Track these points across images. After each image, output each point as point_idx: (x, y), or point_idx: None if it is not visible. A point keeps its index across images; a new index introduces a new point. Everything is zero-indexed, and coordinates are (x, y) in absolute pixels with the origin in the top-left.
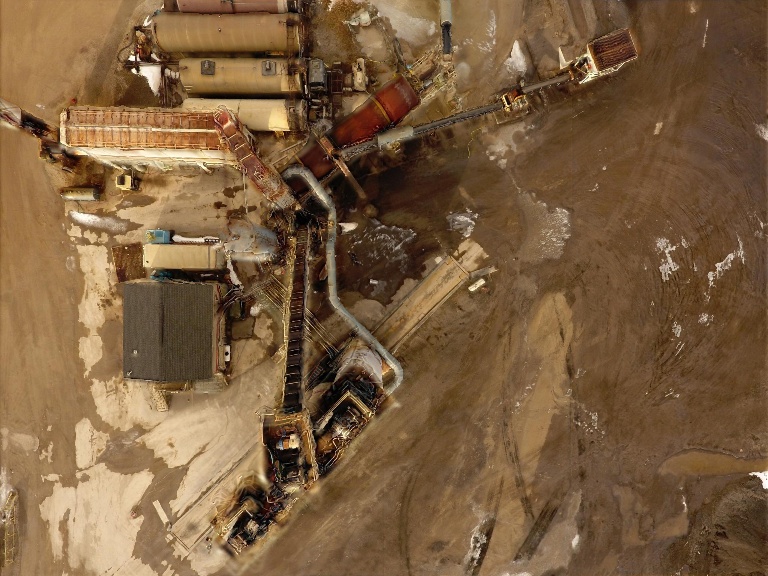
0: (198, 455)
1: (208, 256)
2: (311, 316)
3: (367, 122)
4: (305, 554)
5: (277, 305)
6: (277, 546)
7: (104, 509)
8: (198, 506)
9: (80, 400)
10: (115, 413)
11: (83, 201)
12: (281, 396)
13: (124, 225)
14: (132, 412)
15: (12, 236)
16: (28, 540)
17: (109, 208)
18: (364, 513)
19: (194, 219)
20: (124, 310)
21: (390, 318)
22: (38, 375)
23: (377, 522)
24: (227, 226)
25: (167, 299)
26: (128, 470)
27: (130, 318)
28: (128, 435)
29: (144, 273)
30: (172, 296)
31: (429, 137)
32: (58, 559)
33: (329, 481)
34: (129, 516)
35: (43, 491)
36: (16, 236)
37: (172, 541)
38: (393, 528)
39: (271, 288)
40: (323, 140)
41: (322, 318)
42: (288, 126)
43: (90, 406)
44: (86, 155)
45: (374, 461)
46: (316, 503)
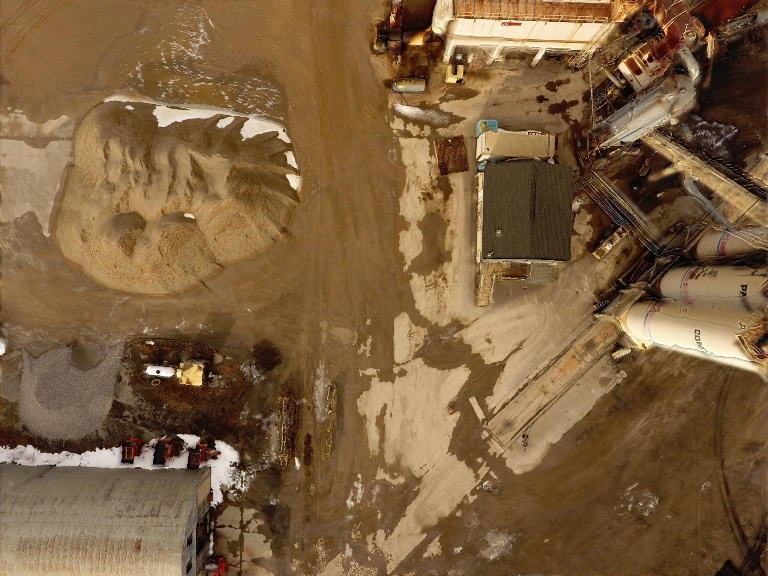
0: (515, 351)
1: (548, 144)
2: (631, 212)
3: (737, 1)
4: (620, 453)
5: (597, 201)
6: (592, 445)
7: (421, 404)
8: (514, 403)
9: (399, 294)
10: (433, 308)
11: (406, 93)
12: (600, 292)
13: (447, 118)
14: (451, 307)
15: (336, 128)
16: (345, 435)
17: (432, 101)
18: (679, 413)
19: (516, 113)
20: (485, 190)
21: (710, 215)
22: (358, 268)
23: (692, 422)
24: (672, 79)
25: (538, 176)
26: (445, 365)
27: (492, 198)
28: (446, 330)
29: (466, 166)
30: (542, 174)
31: (753, 32)
32: (374, 454)
33: (645, 380)
34: (445, 412)
35: (360, 385)
36: (340, 128)
37: (488, 438)
38: (708, 428)
39: (591, 183)
40: (693, 19)
41: (642, 214)
42: (625, 15)
43: (409, 300)
44: (412, 47)
45: (690, 360)
46: (631, 402)
